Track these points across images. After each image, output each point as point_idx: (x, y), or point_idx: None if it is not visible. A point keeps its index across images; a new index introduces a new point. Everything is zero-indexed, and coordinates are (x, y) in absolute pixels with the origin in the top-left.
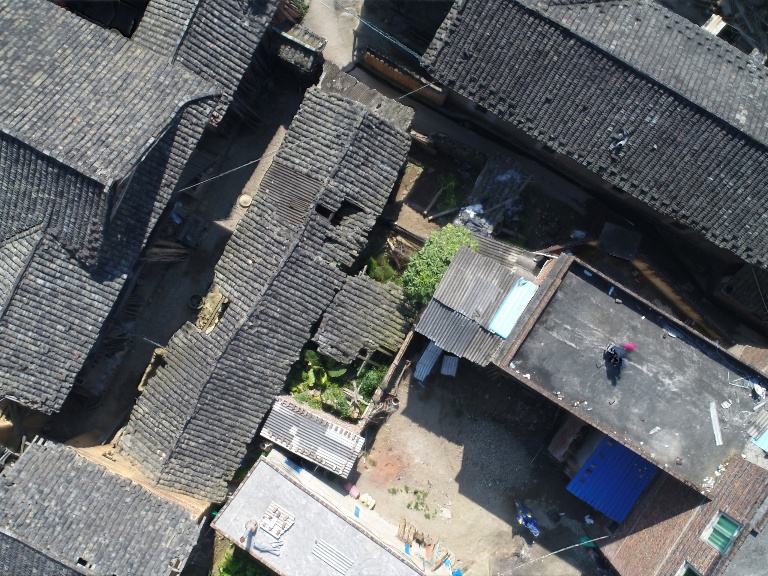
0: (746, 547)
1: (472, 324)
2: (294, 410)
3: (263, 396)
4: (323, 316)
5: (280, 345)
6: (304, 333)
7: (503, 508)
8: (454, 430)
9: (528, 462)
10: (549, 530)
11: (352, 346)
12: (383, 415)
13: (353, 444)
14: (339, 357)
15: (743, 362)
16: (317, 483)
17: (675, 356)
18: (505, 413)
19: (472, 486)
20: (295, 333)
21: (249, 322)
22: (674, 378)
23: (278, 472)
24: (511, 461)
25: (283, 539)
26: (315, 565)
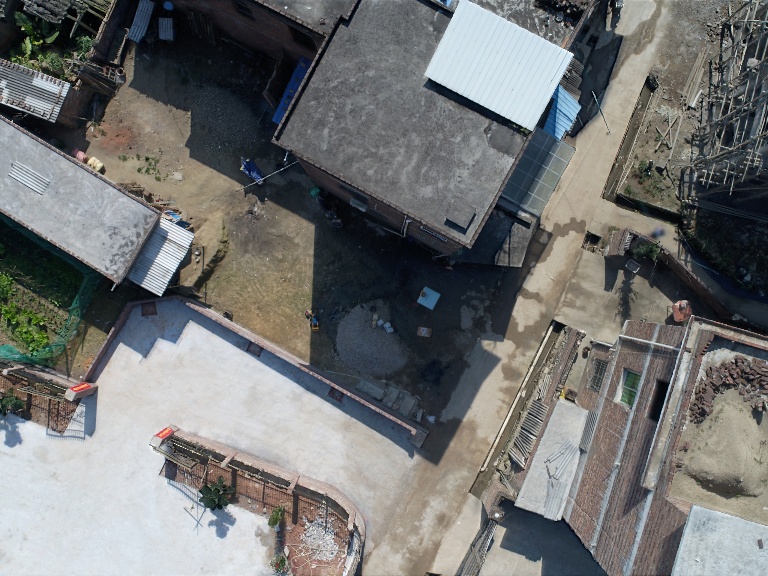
0: (340, 38)
1: None
2: (2, 64)
3: None
4: None
5: None
6: None
7: (234, 168)
8: (180, 97)
9: (255, 122)
10: (280, 186)
11: (59, 4)
12: (107, 84)
13: (59, 89)
14: (47, 16)
15: None
16: None
17: None
18: (229, 77)
19: (202, 150)
20: None
21: None
22: None
23: None
24: (237, 122)
25: None
26: (13, 187)
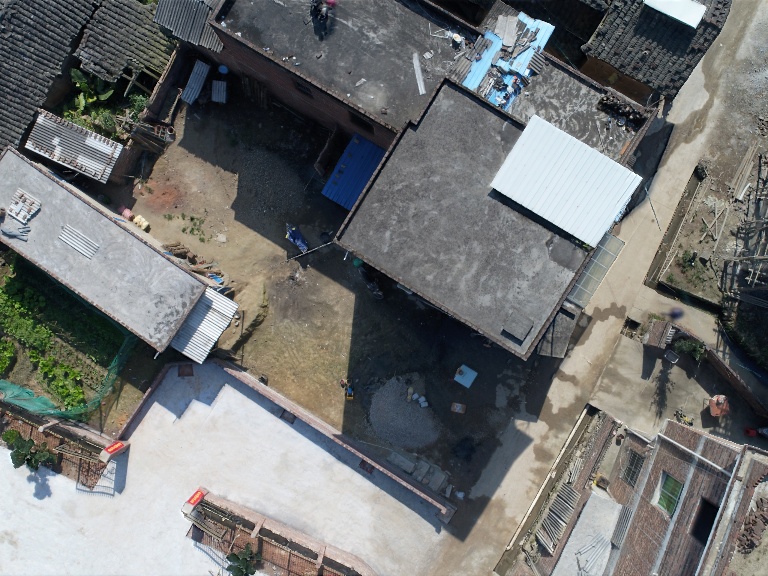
0: (407, 142)
1: (202, 6)
2: (56, 122)
3: (24, 106)
4: (84, 32)
5: (38, 55)
6: (64, 46)
7: (278, 233)
8: (229, 159)
9: (301, 188)
10: (323, 254)
11: (115, 64)
12: (157, 143)
13: (111, 150)
14: (103, 75)
15: (438, 8)
16: (81, 193)
17: (379, 10)
18: (278, 142)
19: (247, 213)
20: (53, 44)
21: (1, 25)
22: (378, 32)
23: (24, 160)
24: (284, 187)
25: (30, 225)
26: (62, 250)
